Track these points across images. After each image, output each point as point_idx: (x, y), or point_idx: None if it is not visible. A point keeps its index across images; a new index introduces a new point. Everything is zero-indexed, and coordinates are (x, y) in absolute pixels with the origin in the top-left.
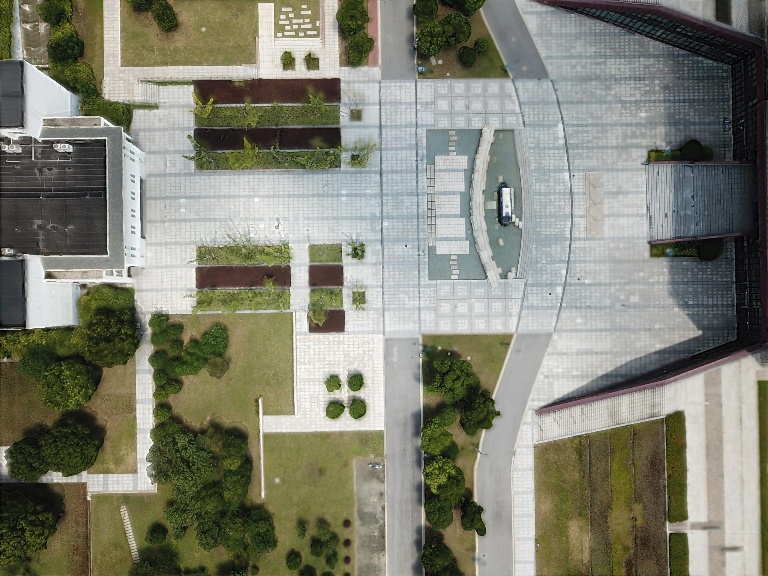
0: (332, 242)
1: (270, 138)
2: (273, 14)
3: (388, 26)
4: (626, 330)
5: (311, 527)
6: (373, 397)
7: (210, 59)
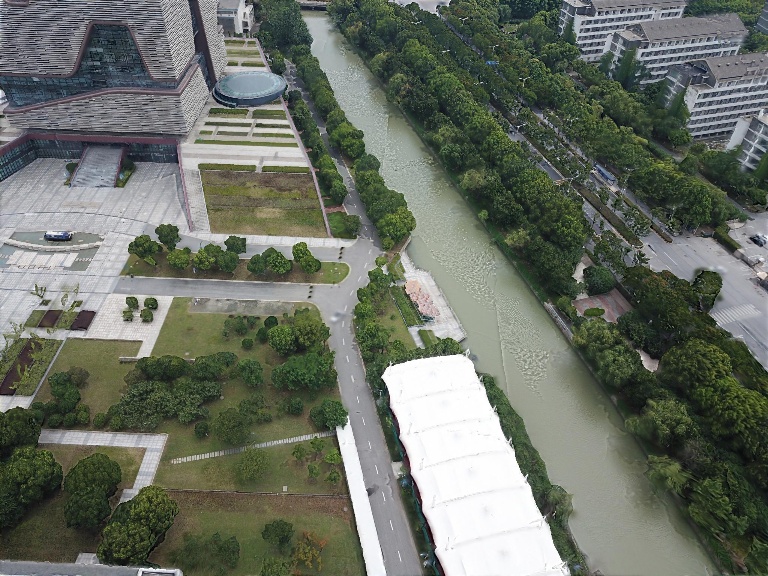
0: (29, 315)
1: None
2: None
3: None
4: (160, 198)
5: None
6: None
7: None
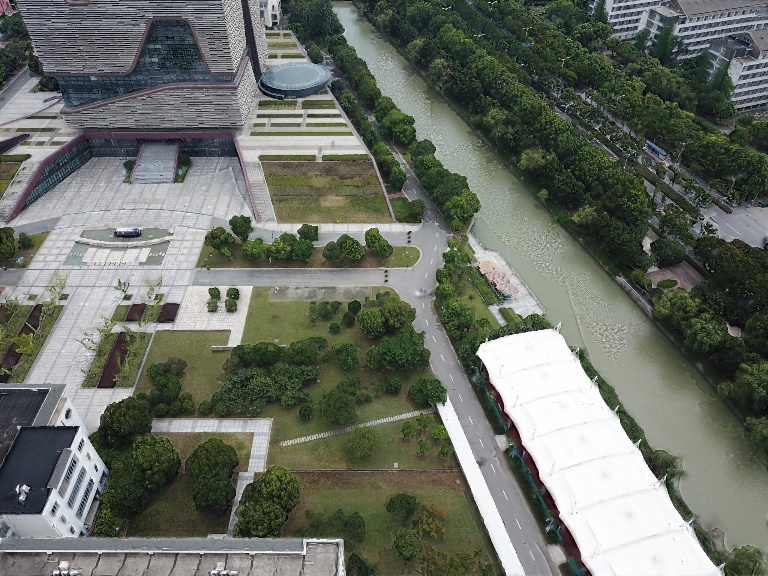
0: (114, 310)
1: None
2: None
3: None
4: (220, 191)
5: None
6: None
7: None
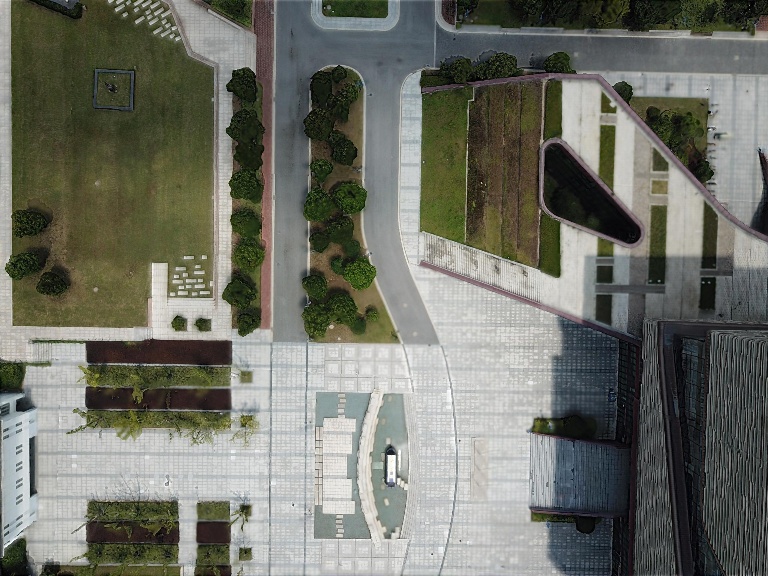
0: (220, 500)
1: (161, 399)
2: (166, 274)
3: (281, 288)
4: None
5: None
6: None
7: (102, 321)
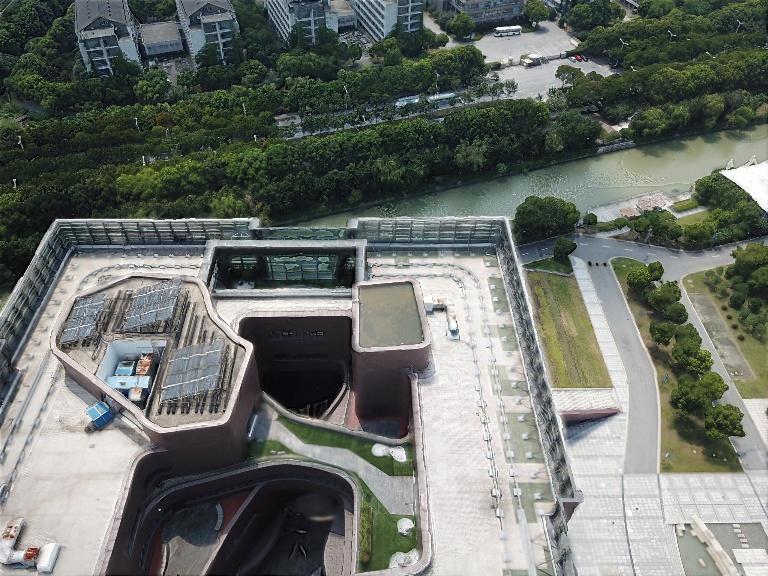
0: None
1: None
2: None
3: None
4: None
5: (767, 336)
6: (764, 423)
7: None
